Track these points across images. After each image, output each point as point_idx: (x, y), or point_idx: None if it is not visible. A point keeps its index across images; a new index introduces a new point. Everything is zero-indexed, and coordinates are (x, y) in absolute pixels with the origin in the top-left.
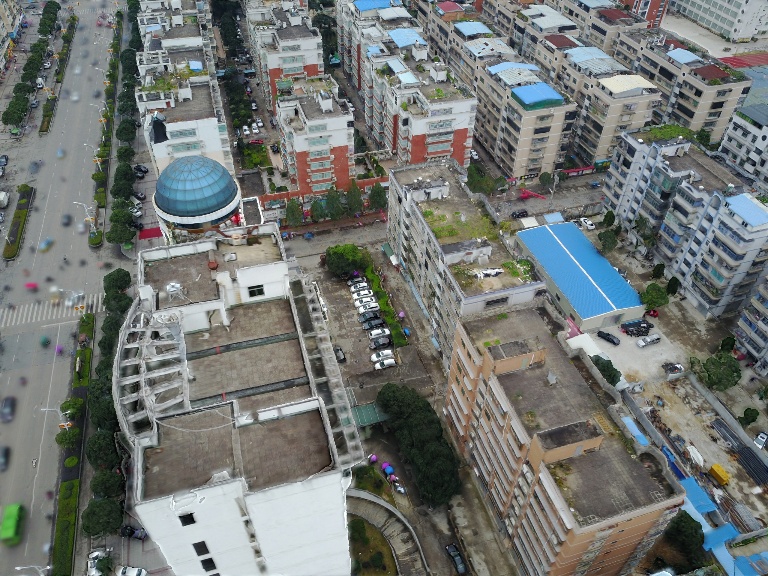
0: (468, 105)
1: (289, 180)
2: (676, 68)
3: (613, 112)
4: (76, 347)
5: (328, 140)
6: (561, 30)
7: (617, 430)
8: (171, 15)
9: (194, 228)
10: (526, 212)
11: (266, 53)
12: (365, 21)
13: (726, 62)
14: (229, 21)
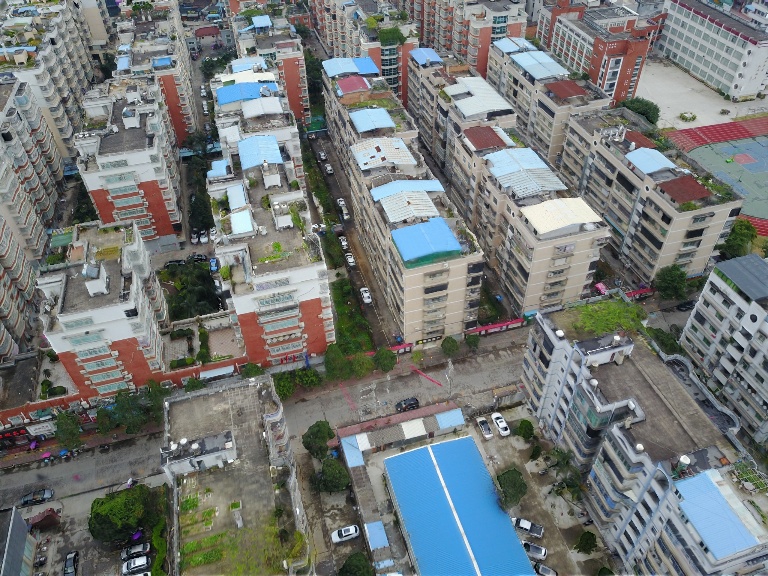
0: (313, 271)
1: None
2: (637, 178)
3: (540, 256)
4: None
5: (100, 335)
6: (491, 116)
7: None
8: None
9: None
10: (416, 403)
11: None
12: (224, 118)
13: (723, 131)
14: None
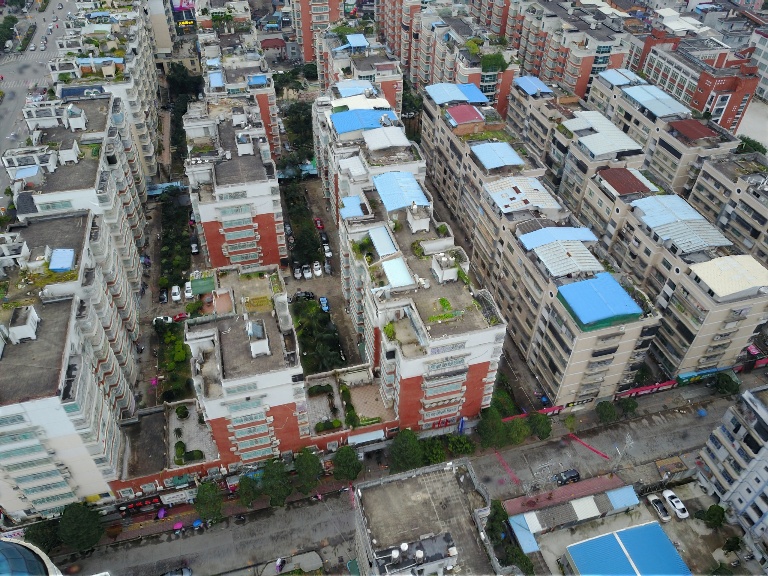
0: (491, 334)
1: None
2: None
3: (713, 319)
4: None
5: (261, 401)
6: (620, 156)
7: None
8: None
9: None
10: (577, 475)
11: (197, 201)
12: (344, 148)
13: None
14: (183, 108)
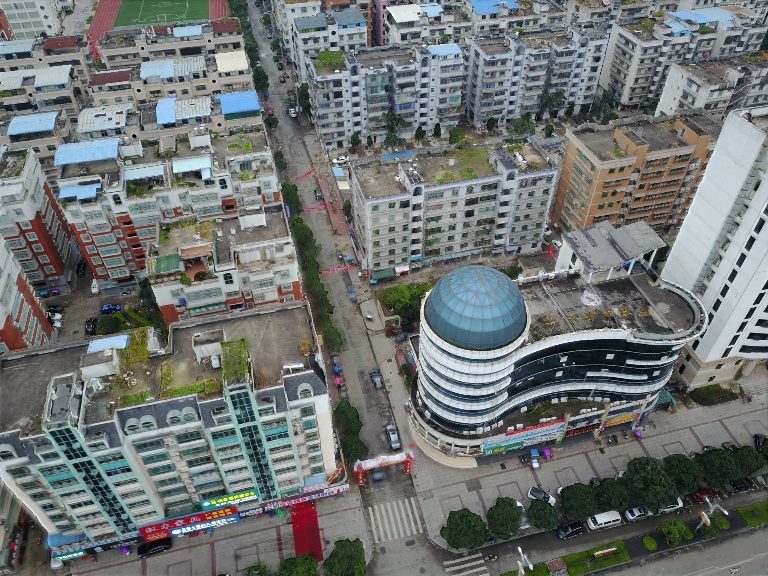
0: None
1: None
2: (198, 41)
3: None
4: None
5: None
6: (71, 76)
7: (666, 122)
8: None
9: None
10: None
11: None
12: None
13: None
14: None
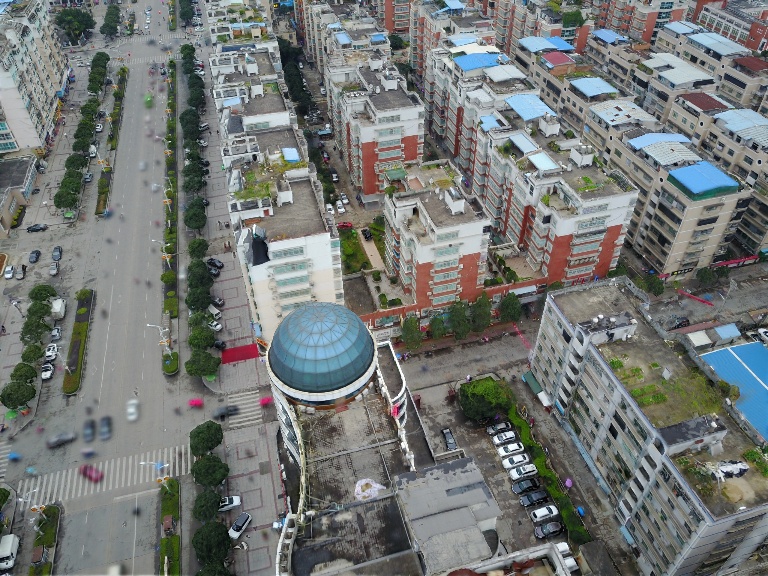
0: (627, 199)
1: (400, 287)
2: None
3: None
4: (159, 532)
5: (458, 248)
6: (696, 85)
7: None
8: (250, 84)
9: (323, 404)
10: (688, 321)
11: (359, 125)
12: (470, 82)
13: None
14: (295, 72)
